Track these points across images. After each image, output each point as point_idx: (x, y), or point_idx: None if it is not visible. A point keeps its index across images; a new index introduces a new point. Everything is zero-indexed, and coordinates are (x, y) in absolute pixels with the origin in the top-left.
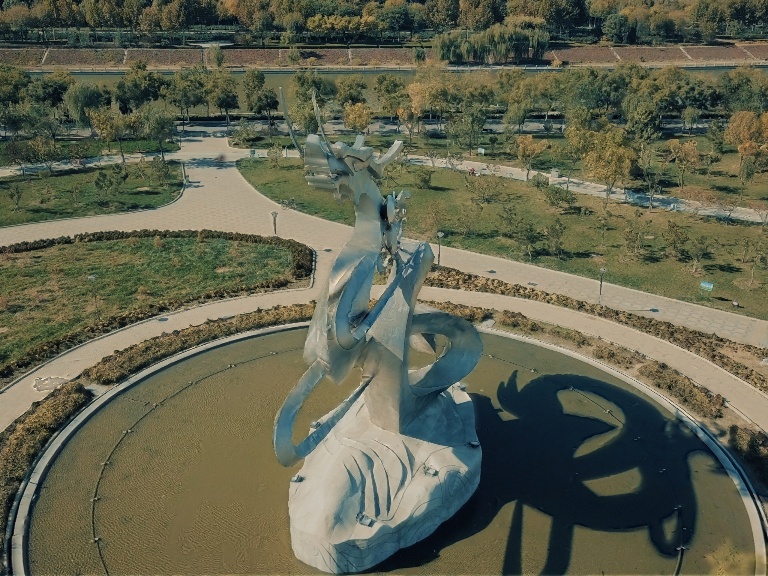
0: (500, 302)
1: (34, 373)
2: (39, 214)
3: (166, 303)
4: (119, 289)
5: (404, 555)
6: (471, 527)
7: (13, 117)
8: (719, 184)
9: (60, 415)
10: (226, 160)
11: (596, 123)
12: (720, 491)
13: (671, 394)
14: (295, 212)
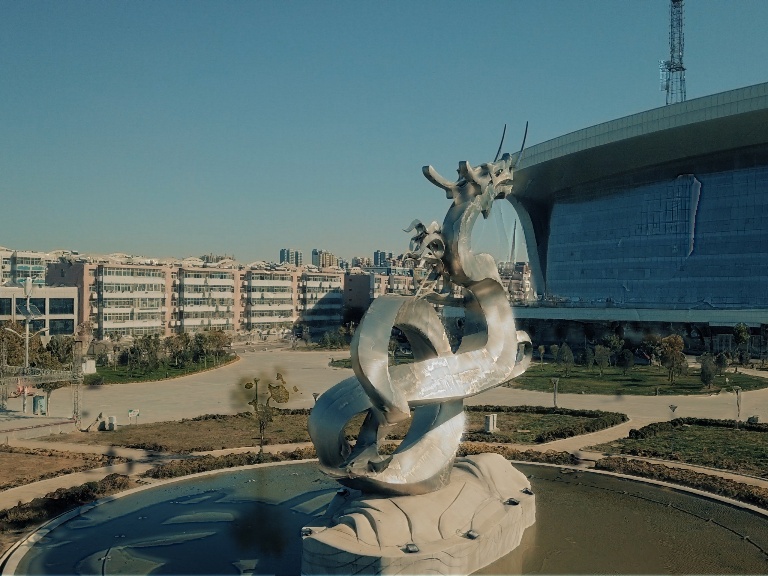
0: None
1: None
2: None
3: None
4: None
5: None
6: None
7: None
8: None
9: None
10: None
11: None
12: (115, 508)
13: None
14: None
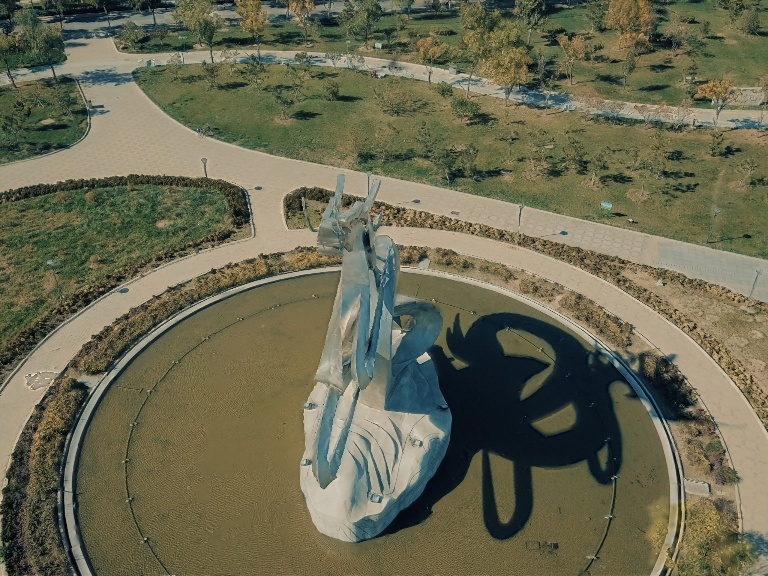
0: (430, 237)
1: (21, 369)
2: None
3: (121, 271)
4: (69, 259)
5: (404, 515)
6: (451, 481)
7: None
8: (603, 73)
9: (68, 417)
10: (121, 72)
11: (490, 19)
12: (637, 419)
13: (589, 326)
14: (213, 141)
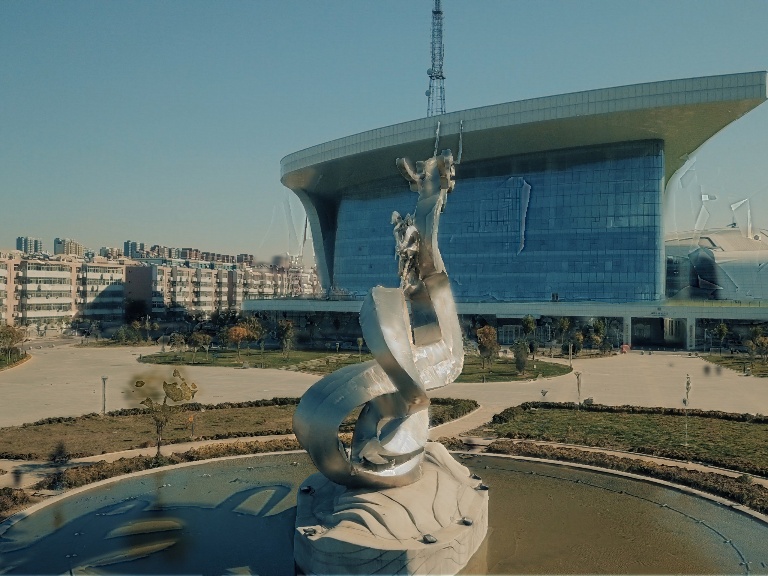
0: None
1: None
2: None
3: None
4: None
5: None
6: None
7: None
8: None
9: None
10: None
11: None
12: (35, 526)
13: None
14: None
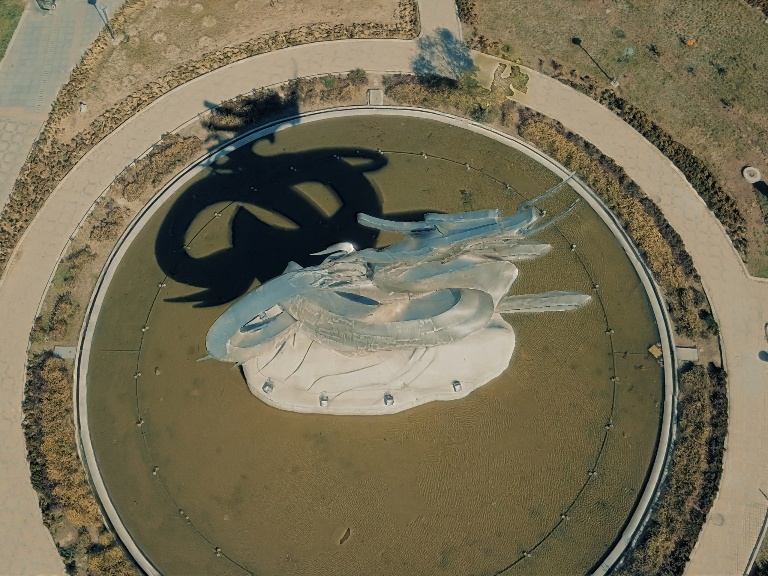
0: None
1: None
2: None
3: None
4: None
5: None
6: None
7: None
8: None
9: None
10: None
11: None
12: (303, 135)
13: (171, 172)
14: None
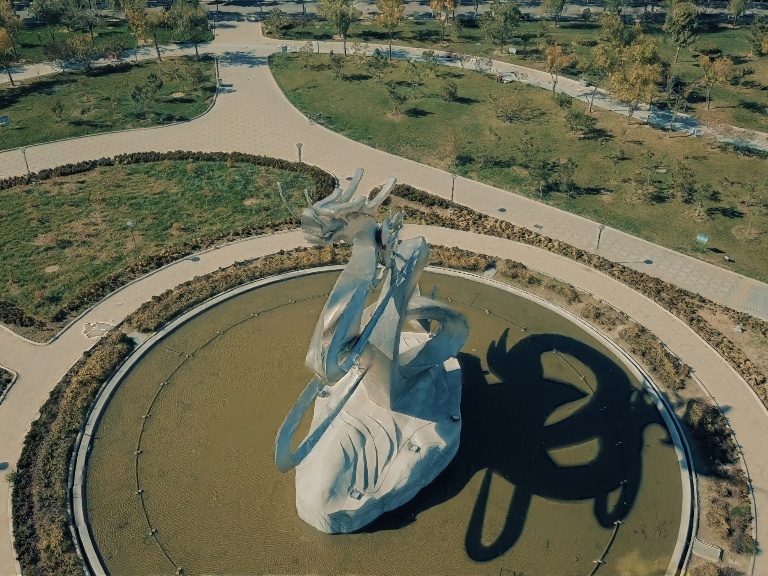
0: (505, 248)
1: (84, 317)
2: (81, 127)
3: (198, 241)
4: (156, 223)
5: (387, 518)
6: (446, 493)
7: (51, 11)
8: (748, 99)
9: (107, 367)
10: (259, 55)
11: (629, 32)
12: (664, 467)
13: (643, 361)
14: (322, 128)
